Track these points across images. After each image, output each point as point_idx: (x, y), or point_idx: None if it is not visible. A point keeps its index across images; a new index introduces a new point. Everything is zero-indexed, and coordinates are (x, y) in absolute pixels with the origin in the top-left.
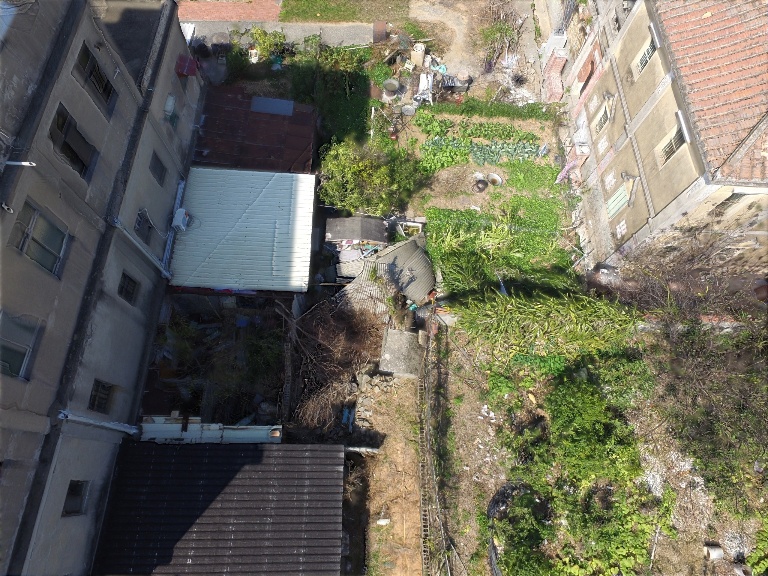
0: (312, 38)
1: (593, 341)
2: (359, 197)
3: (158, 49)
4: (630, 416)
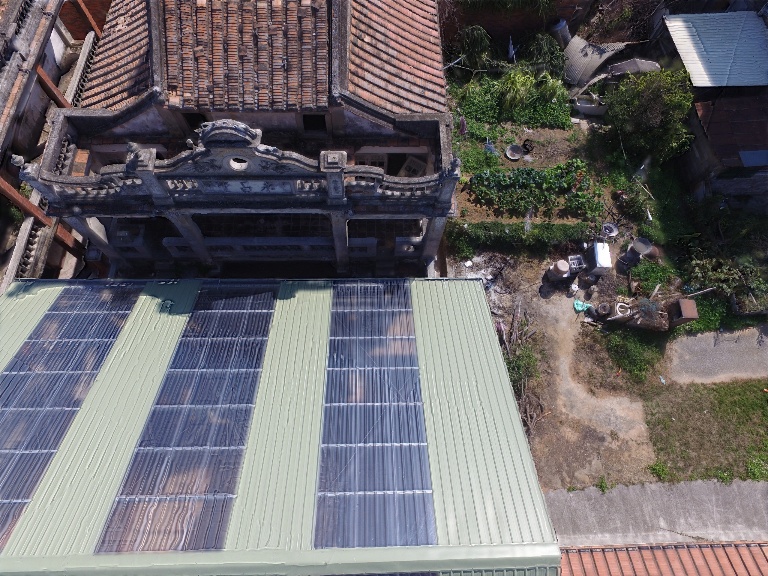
0: (762, 285)
1: None
2: None
3: None
4: None
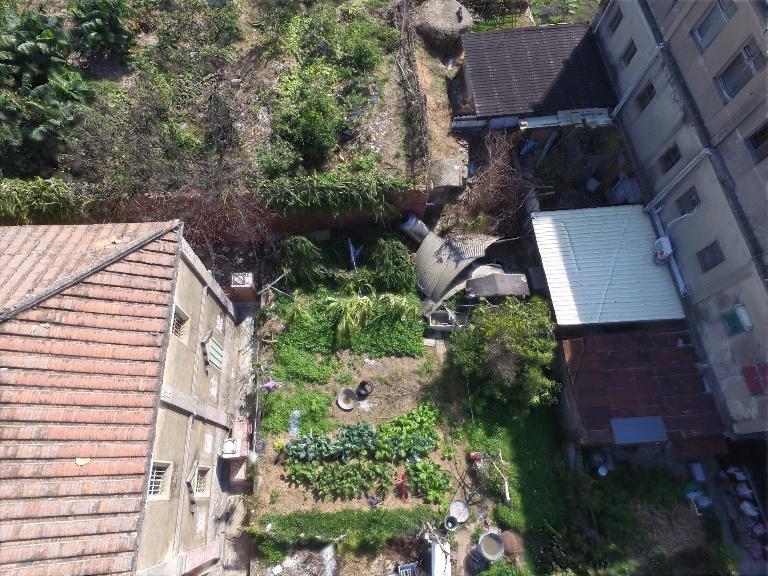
0: None
1: None
2: None
3: None
4: None
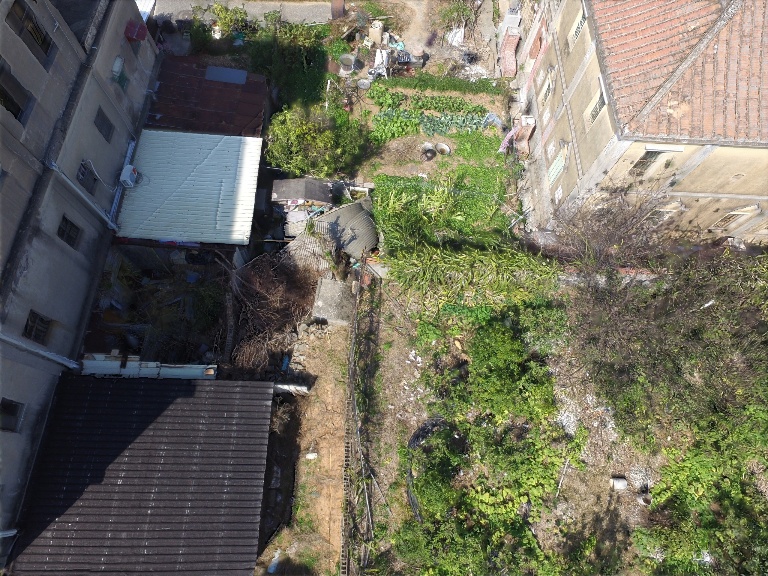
0: (272, 14)
1: (518, 292)
2: (304, 159)
3: (104, 11)
4: (550, 362)
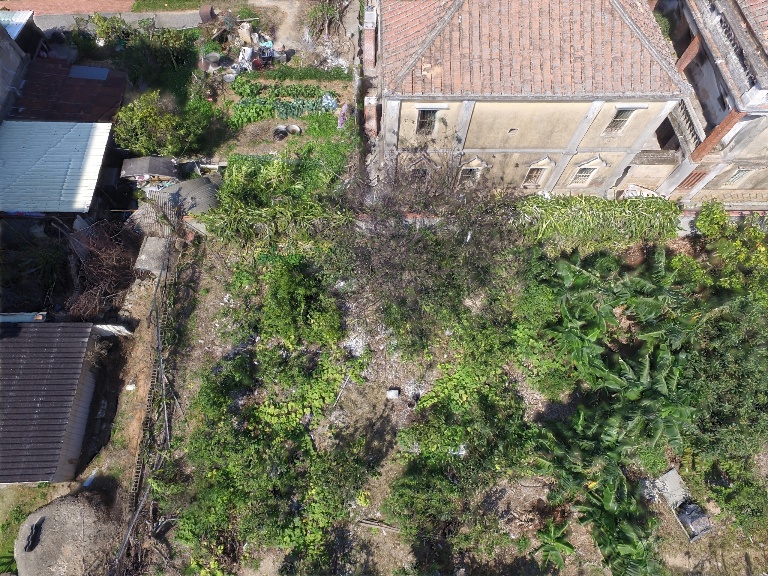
0: (144, 21)
1: (324, 241)
2: (149, 140)
3: None
4: (349, 299)
